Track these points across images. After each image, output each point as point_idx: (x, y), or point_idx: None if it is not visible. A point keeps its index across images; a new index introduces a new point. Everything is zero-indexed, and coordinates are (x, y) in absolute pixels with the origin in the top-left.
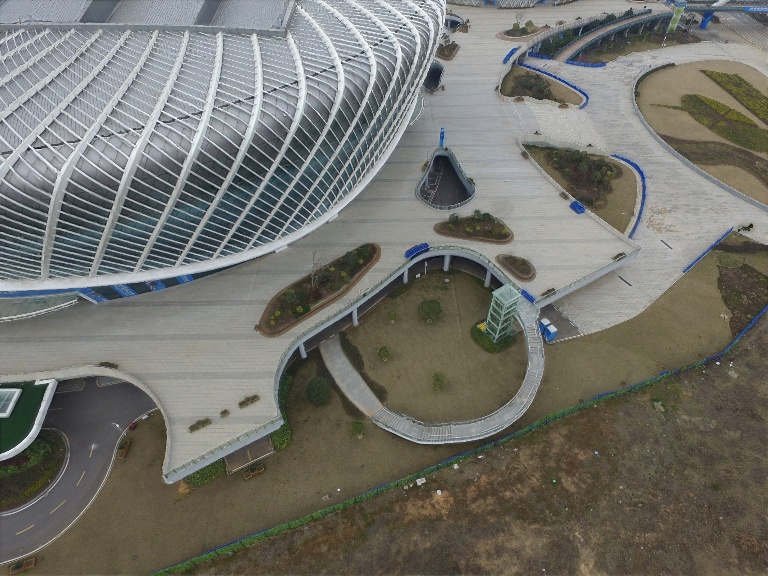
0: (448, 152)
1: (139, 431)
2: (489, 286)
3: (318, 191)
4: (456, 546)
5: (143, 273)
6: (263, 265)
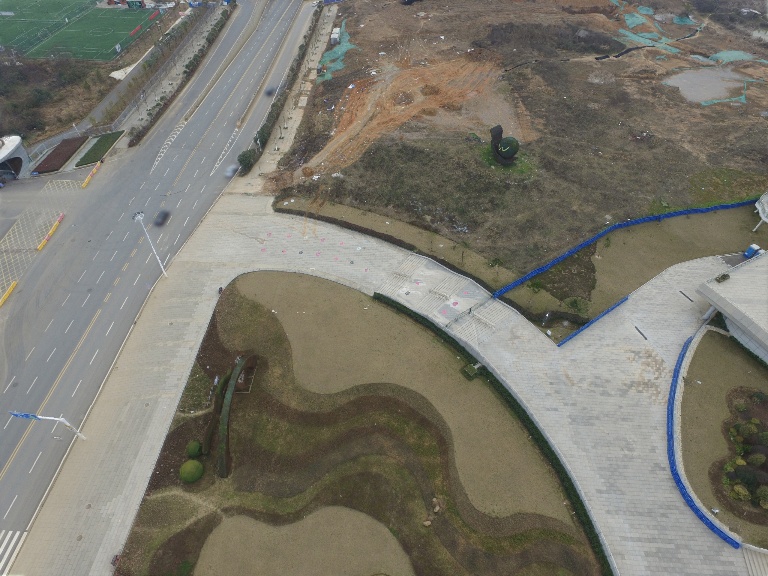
0: None
1: None
2: None
3: None
4: (767, 167)
5: None
6: None
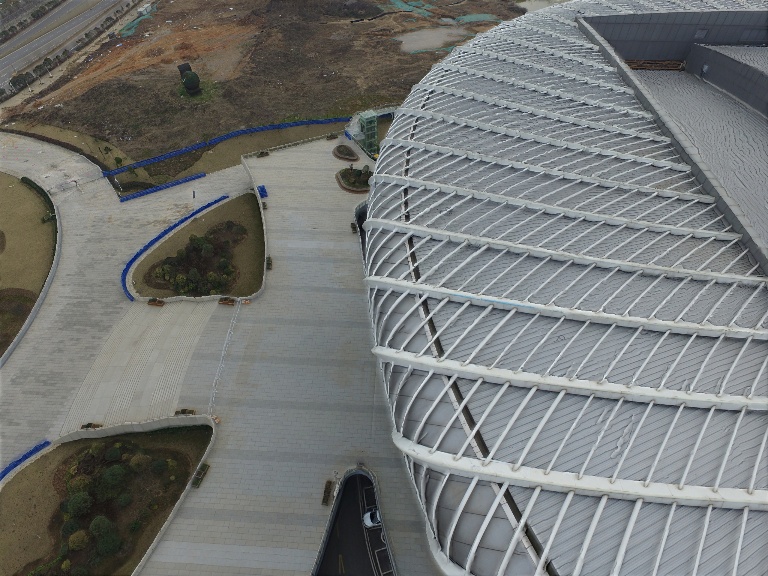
0: None
1: None
2: None
3: None
4: None
5: None
6: None
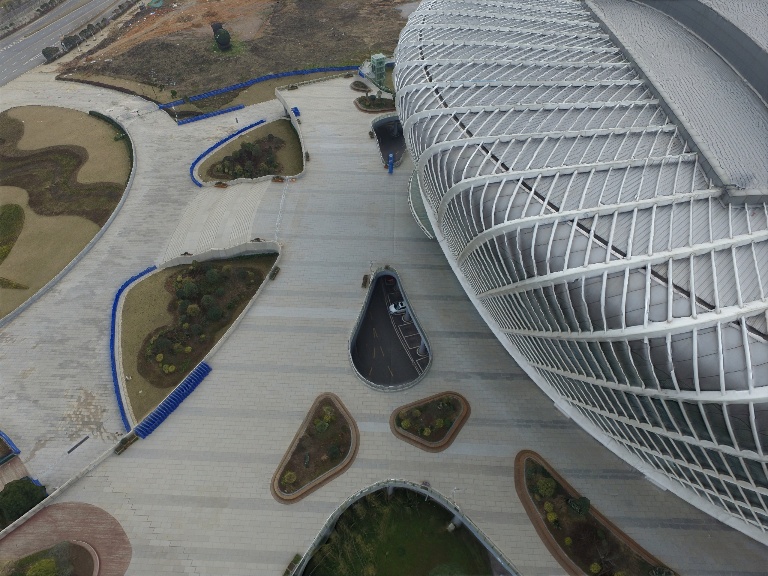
0: None
1: None
2: None
3: None
4: None
5: None
6: None
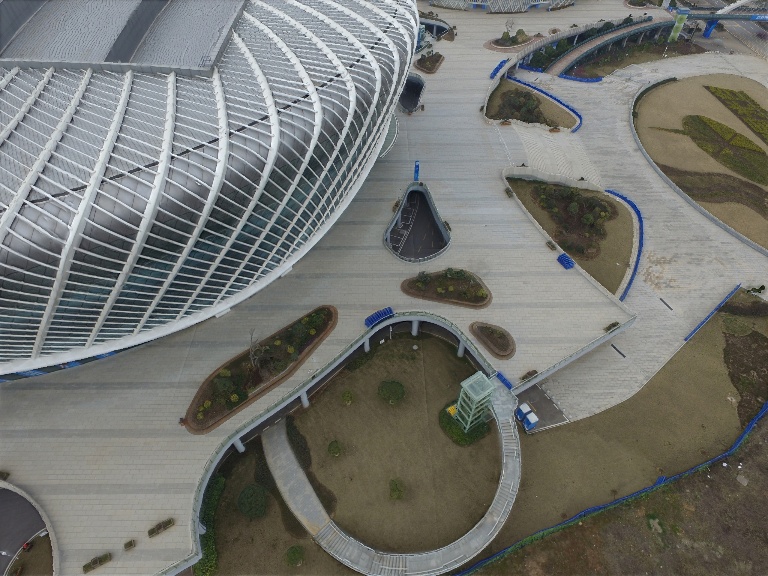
0: (423, 188)
1: (34, 553)
2: (463, 356)
3: (261, 252)
4: None
5: (44, 358)
6: (199, 334)
